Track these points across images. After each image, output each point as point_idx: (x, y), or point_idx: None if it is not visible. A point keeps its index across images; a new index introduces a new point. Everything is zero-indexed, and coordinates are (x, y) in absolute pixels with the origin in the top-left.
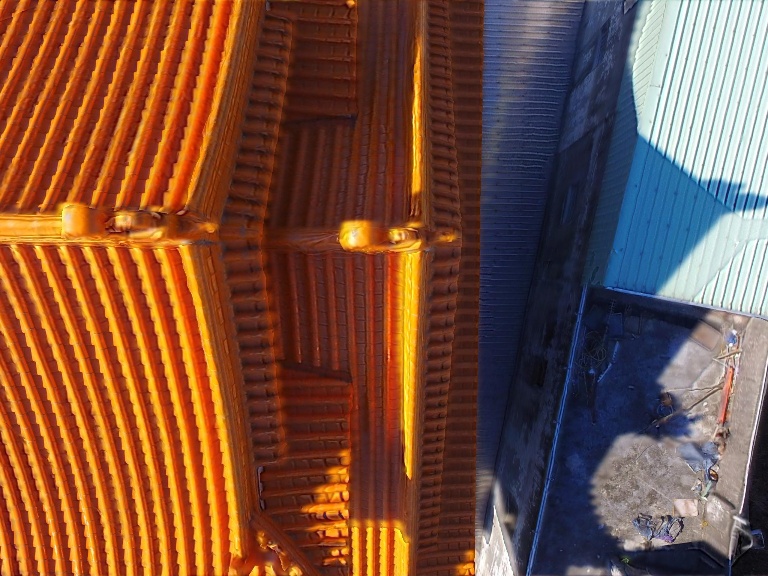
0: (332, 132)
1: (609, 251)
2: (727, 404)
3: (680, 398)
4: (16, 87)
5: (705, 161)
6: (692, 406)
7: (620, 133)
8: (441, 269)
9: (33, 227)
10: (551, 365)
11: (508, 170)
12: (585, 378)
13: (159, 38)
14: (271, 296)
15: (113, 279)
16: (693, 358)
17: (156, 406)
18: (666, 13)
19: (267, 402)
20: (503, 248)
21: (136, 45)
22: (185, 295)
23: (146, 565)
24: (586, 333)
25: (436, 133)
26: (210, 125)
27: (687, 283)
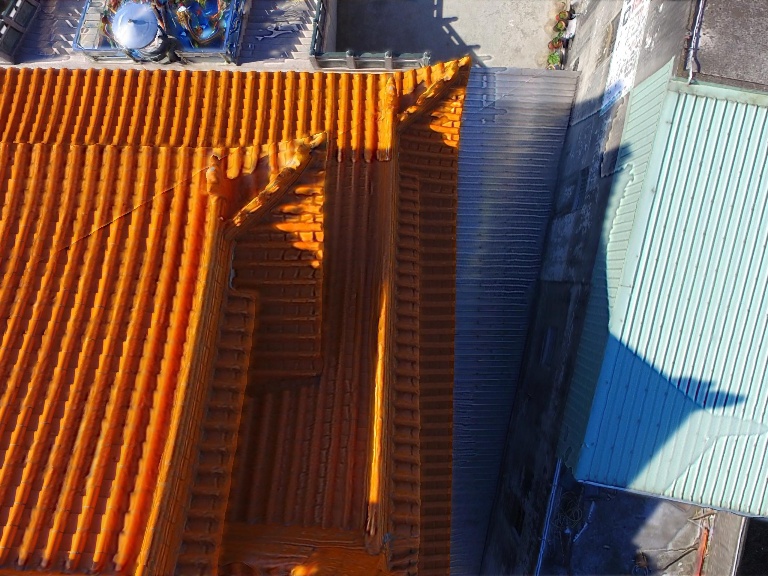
0: (297, 393)
1: (580, 445)
2: (702, 565)
3: (655, 558)
4: None
5: (675, 359)
6: (667, 566)
7: (594, 312)
8: (399, 563)
9: None
10: (528, 521)
11: (490, 296)
12: (561, 538)
13: (122, 325)
14: (233, 573)
15: None
16: (668, 519)
17: None
18: (637, 215)
19: None
20: (485, 373)
21: (99, 334)
22: None
23: None
24: (562, 494)
25: (400, 393)
26: (165, 468)
27: (658, 477)
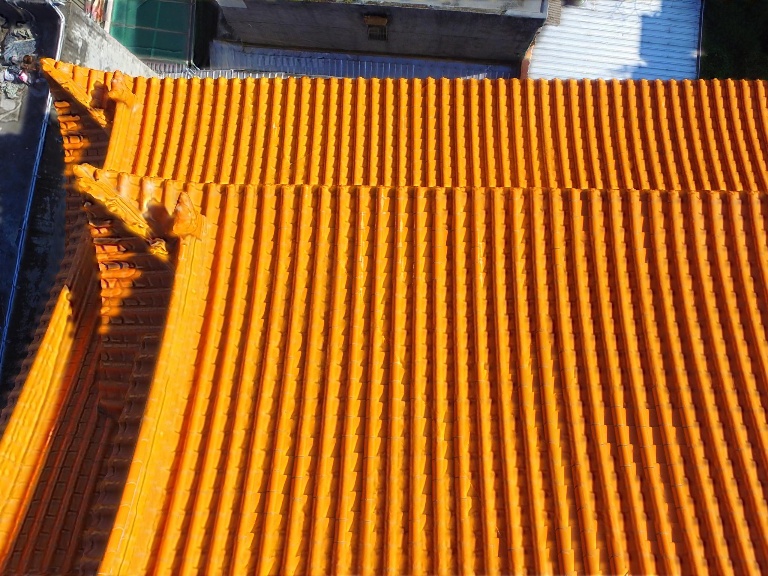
0: None
1: None
2: None
3: None
4: None
5: None
6: None
7: None
8: None
9: None
10: None
11: None
12: None
13: None
14: None
15: None
16: None
17: (244, 412)
18: None
19: (129, 416)
20: None
21: None
22: (153, 568)
23: (308, 209)
24: None
25: None
26: None
27: None
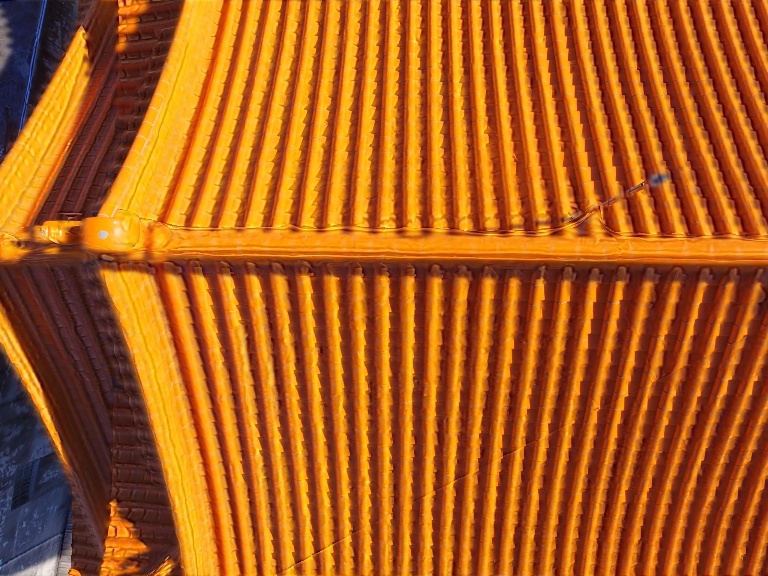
0: None
1: None
2: None
3: None
4: (398, 411)
5: None
6: None
7: None
8: None
9: (244, 238)
10: None
11: None
12: None
13: (270, 464)
14: None
15: (245, 200)
16: None
17: (262, 79)
18: None
19: (148, 86)
20: None
21: (291, 457)
22: (175, 185)
23: None
24: None
25: None
26: (140, 360)
27: None
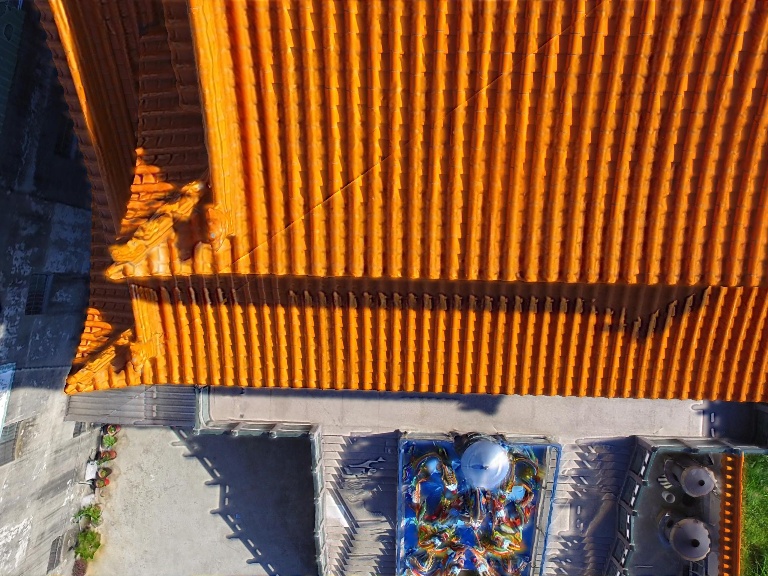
0: (158, 16)
1: None
2: None
3: None
4: None
5: None
6: None
7: None
8: None
9: None
10: None
11: None
12: None
13: (301, 67)
14: None
15: None
16: None
17: None
18: None
19: None
20: None
21: (323, 56)
22: None
23: None
24: None
25: None
26: None
27: None
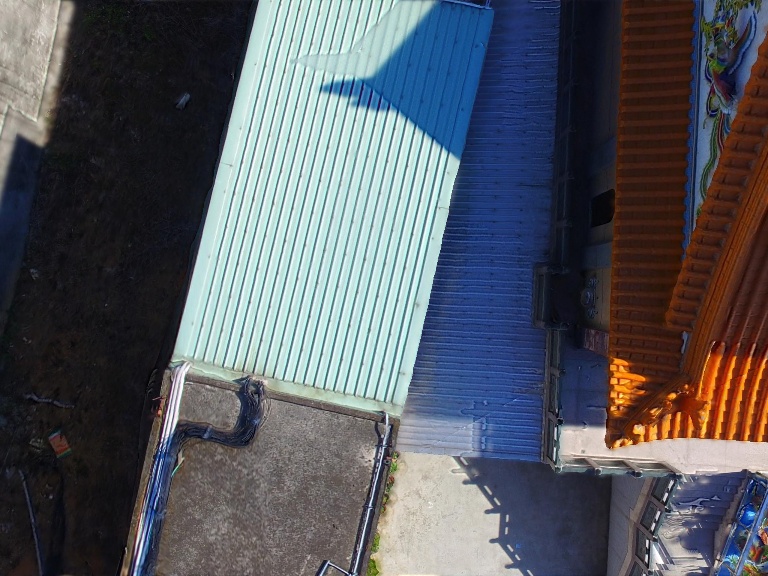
0: None
1: None
2: None
3: None
4: None
5: (393, 133)
6: None
7: None
8: None
9: None
10: None
11: (483, 224)
12: None
13: None
14: None
15: None
16: None
17: None
18: None
19: None
20: (490, 145)
21: None
22: None
23: None
24: None
25: None
26: None
27: (410, 12)
